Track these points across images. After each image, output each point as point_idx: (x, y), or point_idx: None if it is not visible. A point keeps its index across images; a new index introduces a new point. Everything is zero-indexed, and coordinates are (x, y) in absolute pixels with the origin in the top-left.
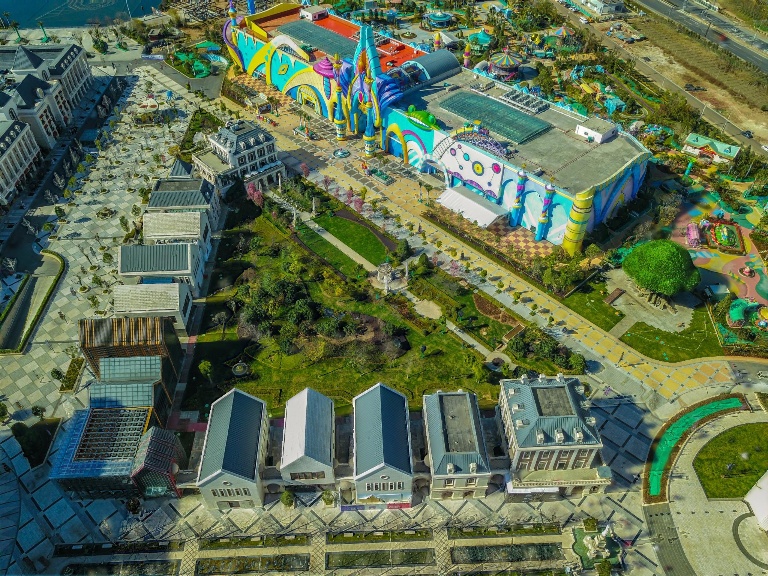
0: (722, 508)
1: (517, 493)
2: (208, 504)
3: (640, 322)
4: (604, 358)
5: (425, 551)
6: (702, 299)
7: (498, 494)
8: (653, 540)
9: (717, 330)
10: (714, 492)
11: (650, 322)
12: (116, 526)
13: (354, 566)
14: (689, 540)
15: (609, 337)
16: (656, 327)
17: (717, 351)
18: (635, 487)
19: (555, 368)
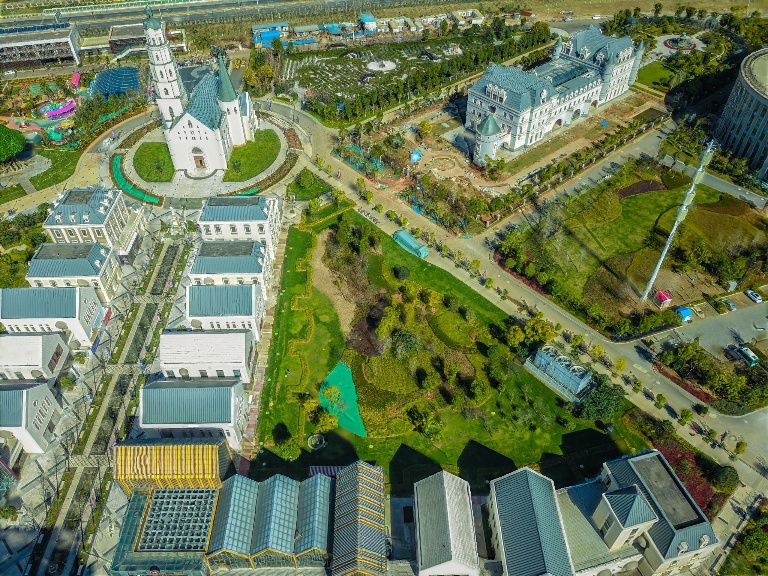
0: (178, 179)
1: (129, 251)
2: (41, 446)
3: (30, 179)
4: (49, 201)
5: (147, 308)
6: (32, 149)
7: (124, 268)
8: (184, 209)
9: (62, 149)
10: (168, 179)
11: (34, 174)
12: (22, 536)
13: (141, 347)
14: (189, 195)
15: (33, 195)
16: (40, 173)
17: (78, 154)
18: (150, 209)
19: (41, 225)
